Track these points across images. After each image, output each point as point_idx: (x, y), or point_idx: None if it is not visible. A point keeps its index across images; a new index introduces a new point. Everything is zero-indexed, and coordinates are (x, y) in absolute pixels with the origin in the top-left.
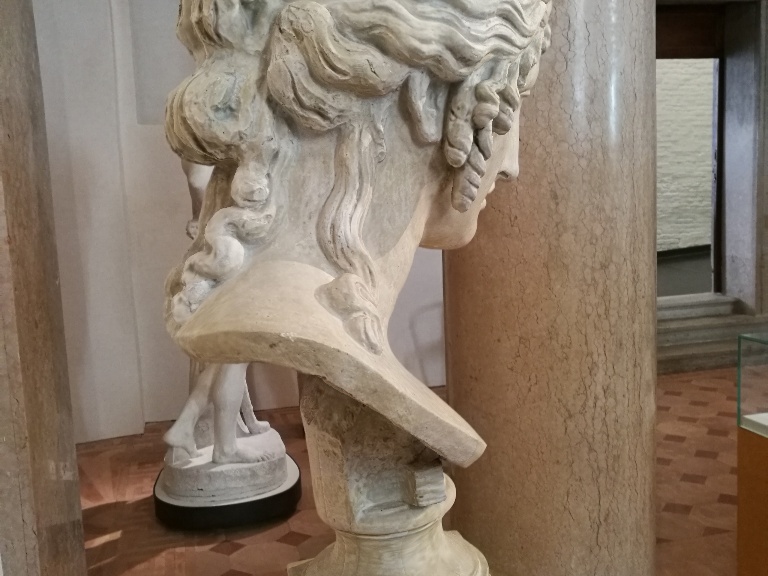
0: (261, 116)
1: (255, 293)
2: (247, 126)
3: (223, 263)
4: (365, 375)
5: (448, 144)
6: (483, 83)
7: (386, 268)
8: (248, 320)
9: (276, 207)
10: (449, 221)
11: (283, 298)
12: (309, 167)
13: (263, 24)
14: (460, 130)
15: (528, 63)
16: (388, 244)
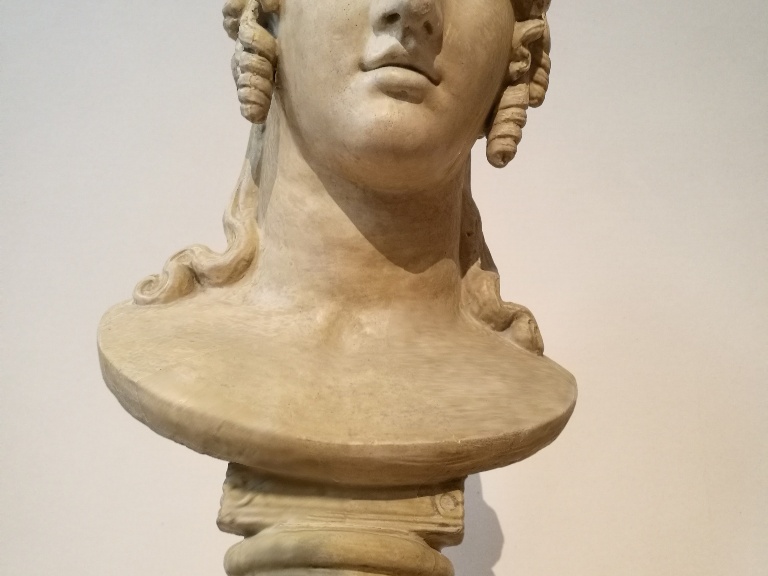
0: None
1: None
2: None
3: None
4: None
5: None
6: None
7: None
8: None
9: None
10: (312, 137)
11: None
12: None
13: None
14: None
15: None
16: None
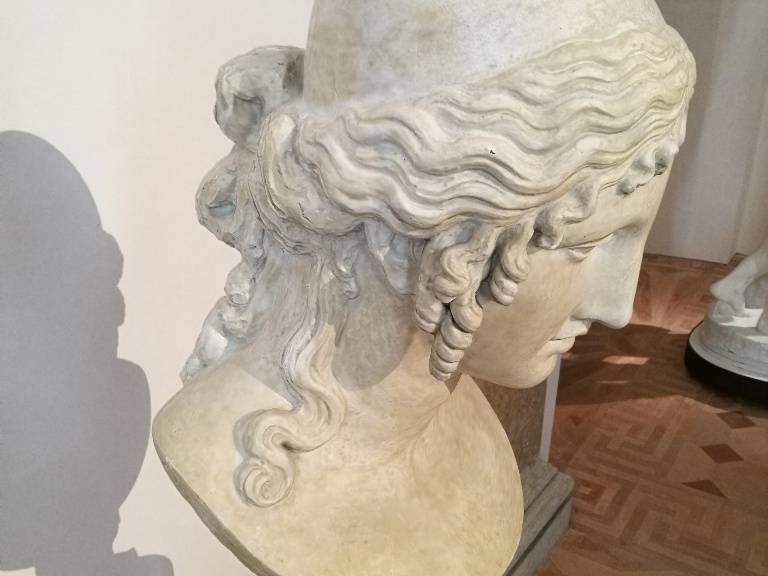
0: (250, 221)
1: (196, 398)
2: (236, 229)
3: (201, 353)
4: (221, 527)
5: None
6: (449, 250)
7: (370, 401)
8: (163, 427)
9: (253, 314)
10: (471, 368)
11: (204, 416)
12: (292, 281)
13: None
14: (419, 297)
15: (548, 224)
16: (369, 380)
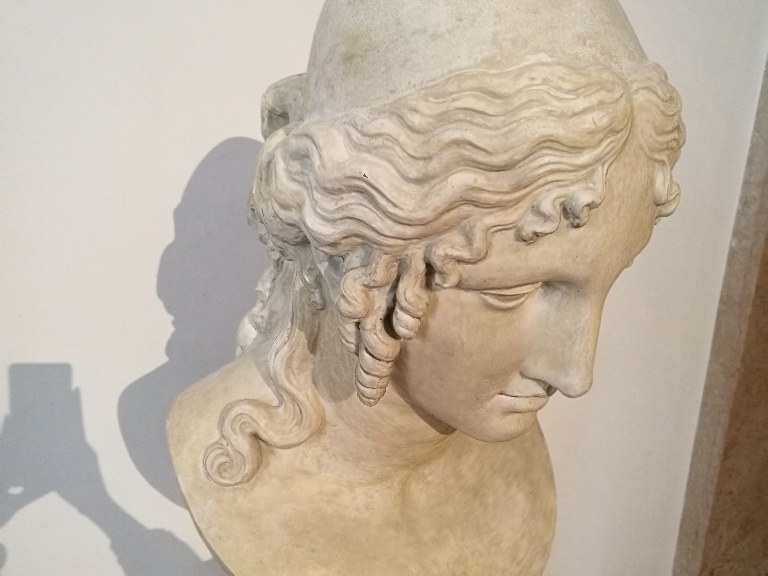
0: None
1: (213, 376)
2: None
3: None
4: None
5: None
6: None
7: (343, 416)
8: None
9: (269, 311)
10: None
11: (208, 392)
12: None
13: None
14: None
15: (431, 259)
16: (339, 394)
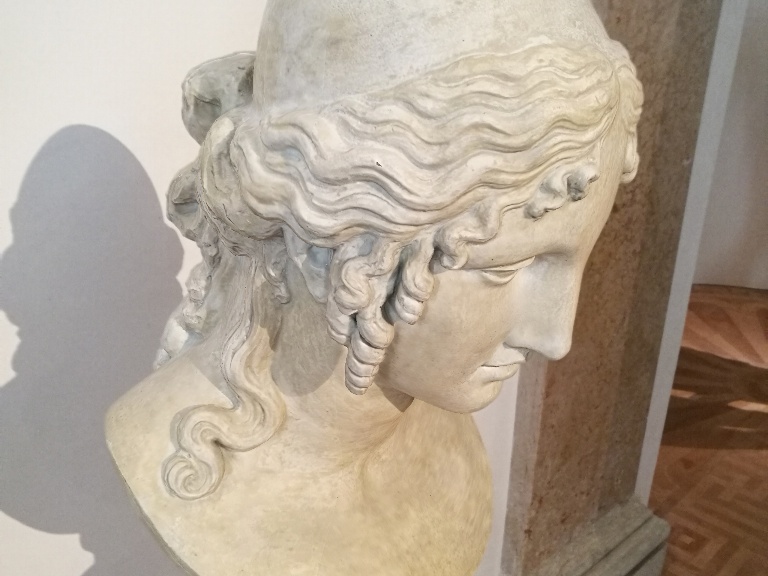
0: None
1: (148, 386)
2: (196, 226)
3: (164, 344)
4: (142, 514)
5: None
6: (349, 261)
7: (308, 408)
8: (114, 411)
9: (207, 311)
10: None
11: (149, 404)
12: (241, 281)
13: None
14: (328, 307)
15: (444, 243)
16: (304, 387)
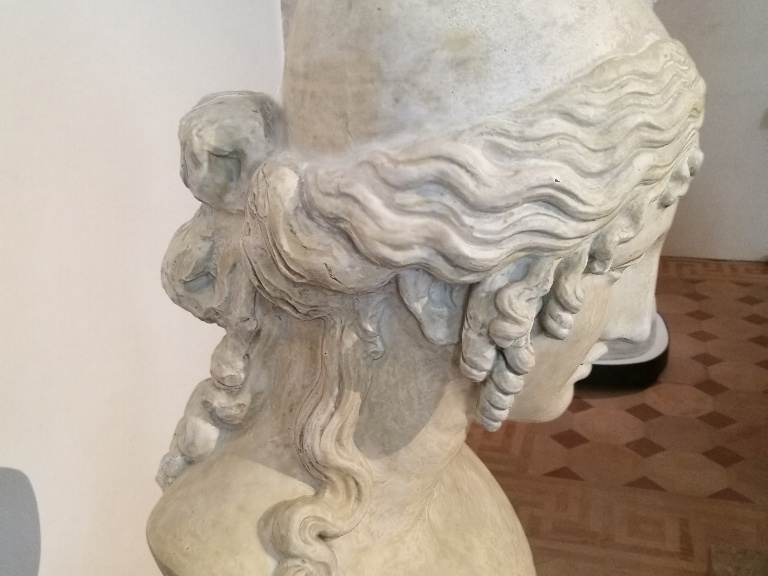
0: (238, 290)
1: (199, 503)
2: (221, 302)
3: (189, 449)
4: None
5: (462, 354)
6: (506, 290)
7: (397, 466)
8: (170, 546)
9: (251, 395)
10: None
11: (218, 522)
12: (296, 350)
13: (243, 180)
14: (470, 346)
15: (605, 248)
16: (396, 443)
